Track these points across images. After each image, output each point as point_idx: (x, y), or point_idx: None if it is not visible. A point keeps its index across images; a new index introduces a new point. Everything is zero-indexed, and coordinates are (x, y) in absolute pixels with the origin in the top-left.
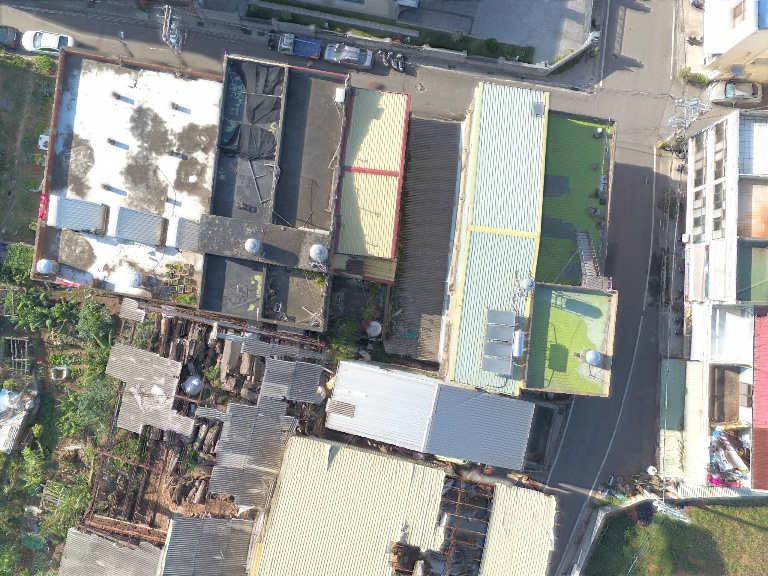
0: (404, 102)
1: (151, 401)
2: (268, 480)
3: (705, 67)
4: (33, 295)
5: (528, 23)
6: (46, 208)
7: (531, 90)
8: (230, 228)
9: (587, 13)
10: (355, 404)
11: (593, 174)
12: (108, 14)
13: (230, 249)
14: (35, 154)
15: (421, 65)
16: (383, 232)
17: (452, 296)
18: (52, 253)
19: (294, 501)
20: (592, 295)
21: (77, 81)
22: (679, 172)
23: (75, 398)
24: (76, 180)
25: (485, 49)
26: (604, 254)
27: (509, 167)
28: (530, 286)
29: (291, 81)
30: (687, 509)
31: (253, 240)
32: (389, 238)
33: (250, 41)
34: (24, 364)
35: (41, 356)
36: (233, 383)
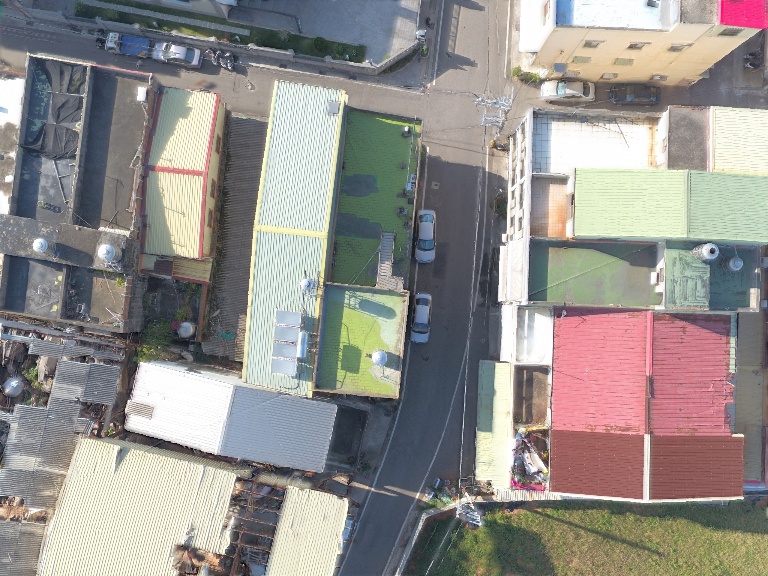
0: (213, 101)
1: None
2: (61, 483)
3: (537, 66)
4: None
5: (360, 22)
6: None
7: (327, 88)
8: (25, 228)
9: None
10: (153, 406)
11: (401, 173)
12: None
13: (24, 249)
14: None
15: (252, 64)
16: (189, 232)
17: None
18: None
19: (78, 504)
20: (386, 295)
21: None
22: None
23: None
24: None
25: None
26: (409, 254)
27: (300, 166)
28: (307, 286)
29: (97, 80)
30: (517, 512)
31: (40, 240)
32: (196, 238)
33: (80, 40)
34: None
35: None
36: None
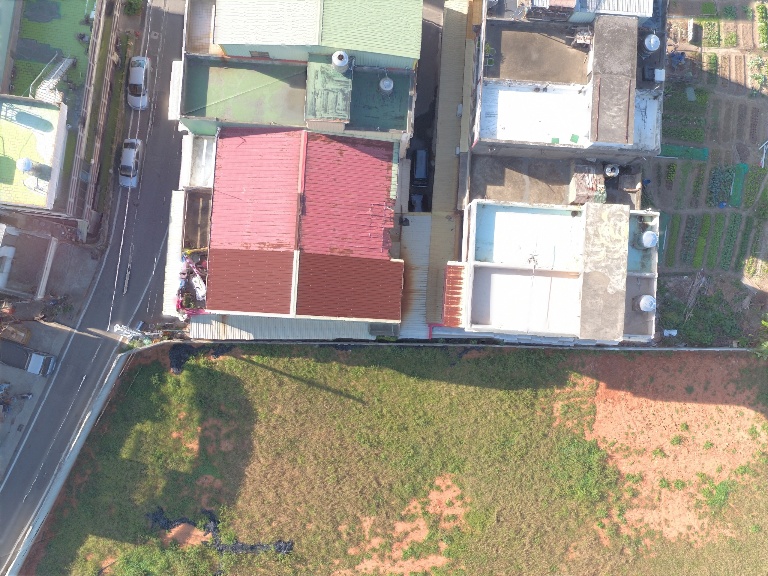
0: None
1: None
2: None
3: None
4: None
5: None
6: None
7: None
8: None
9: None
10: None
11: (85, 1)
12: None
13: None
14: None
15: None
16: None
17: None
18: None
19: None
20: (44, 109)
21: None
22: None
23: None
24: None
25: None
26: None
27: None
28: None
29: None
30: (223, 359)
31: None
32: None
33: None
34: None
35: None
36: None
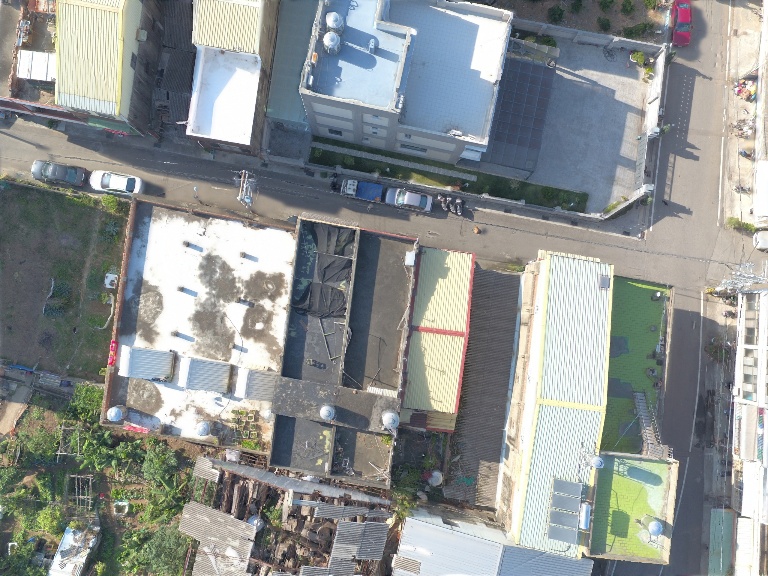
0: (469, 261)
1: (225, 562)
2: None
3: (751, 217)
4: (98, 433)
5: (582, 169)
6: (115, 354)
7: (596, 263)
8: (303, 391)
9: (639, 162)
10: (421, 561)
11: (651, 335)
12: (174, 154)
13: (303, 411)
14: (102, 294)
15: (478, 209)
16: (448, 389)
17: (514, 453)
18: (120, 397)
19: None
20: (653, 463)
21: (147, 228)
22: (725, 317)
23: (139, 538)
24: (145, 326)
25: (540, 195)
26: (661, 415)
27: (576, 340)
28: (599, 466)
29: (361, 241)
30: None
31: (328, 408)
32: (453, 394)
33: (312, 183)
34: (88, 501)
35: (103, 491)
36: (294, 524)
